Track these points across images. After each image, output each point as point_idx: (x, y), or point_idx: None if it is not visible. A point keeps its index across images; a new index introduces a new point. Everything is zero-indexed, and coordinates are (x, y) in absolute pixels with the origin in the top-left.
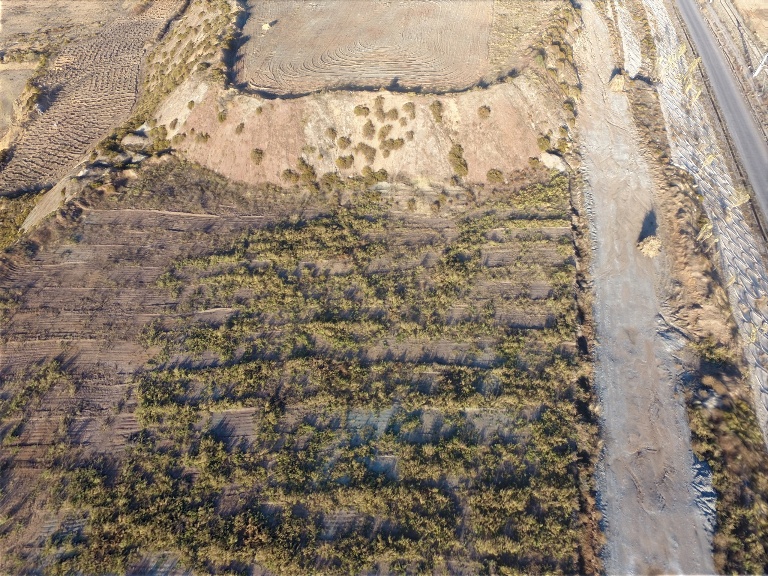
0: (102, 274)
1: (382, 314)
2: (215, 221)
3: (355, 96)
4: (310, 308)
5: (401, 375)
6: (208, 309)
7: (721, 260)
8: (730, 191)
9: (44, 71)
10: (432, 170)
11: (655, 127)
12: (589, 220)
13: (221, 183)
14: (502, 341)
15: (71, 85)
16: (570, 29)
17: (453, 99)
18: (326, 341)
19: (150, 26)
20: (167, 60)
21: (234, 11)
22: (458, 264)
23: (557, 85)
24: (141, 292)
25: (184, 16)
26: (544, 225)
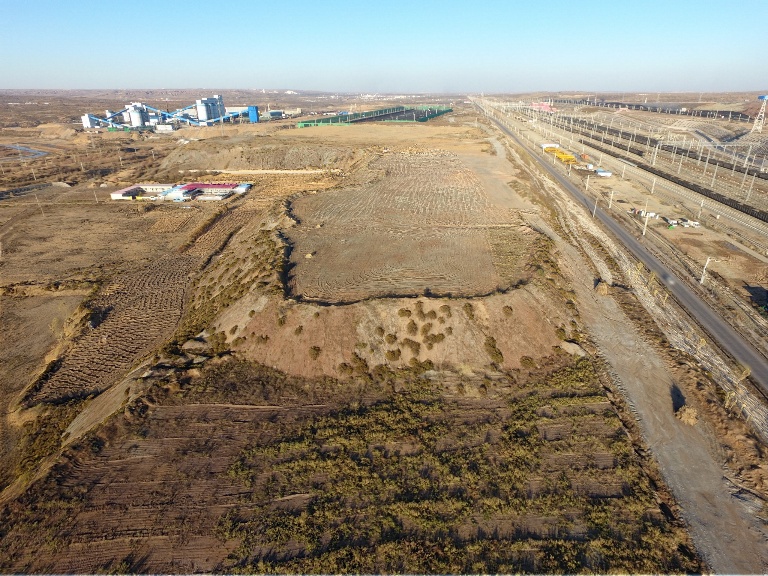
0: (171, 467)
1: (462, 491)
2: (279, 411)
3: (398, 302)
4: (389, 489)
5: (500, 554)
6: (285, 496)
7: (753, 425)
8: (727, 370)
9: (96, 296)
10: (472, 359)
11: (645, 320)
12: (623, 395)
13: (281, 377)
14: (588, 512)
15: (122, 306)
16: (551, 253)
17: (480, 302)
18: (413, 522)
19: (193, 260)
20: (214, 283)
21: (280, 246)
22: (521, 439)
23: (557, 291)
24: (213, 483)
25: (224, 252)
26: (585, 401)
